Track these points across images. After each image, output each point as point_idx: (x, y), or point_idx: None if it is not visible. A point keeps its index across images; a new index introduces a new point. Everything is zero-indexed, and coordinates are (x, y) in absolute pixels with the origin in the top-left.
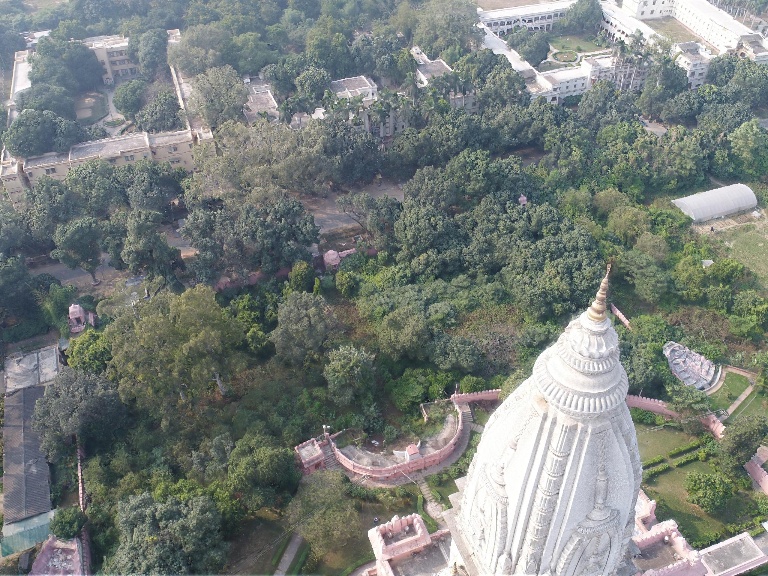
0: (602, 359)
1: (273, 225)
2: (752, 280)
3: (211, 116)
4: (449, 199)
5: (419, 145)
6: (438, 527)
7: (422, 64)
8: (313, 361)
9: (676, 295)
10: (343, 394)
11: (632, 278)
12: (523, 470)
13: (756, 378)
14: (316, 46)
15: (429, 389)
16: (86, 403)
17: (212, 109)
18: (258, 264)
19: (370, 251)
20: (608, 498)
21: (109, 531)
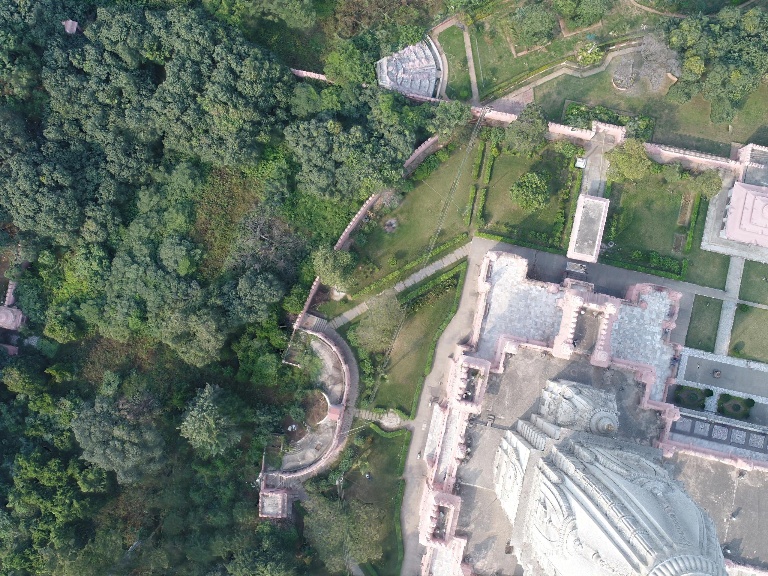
0: None
1: None
2: None
3: None
4: (17, 129)
5: None
6: (408, 429)
7: None
8: None
9: None
10: (229, 438)
11: (272, 14)
12: None
13: (461, 19)
14: None
15: (273, 345)
16: None
17: None
18: None
19: (25, 264)
20: None
21: None
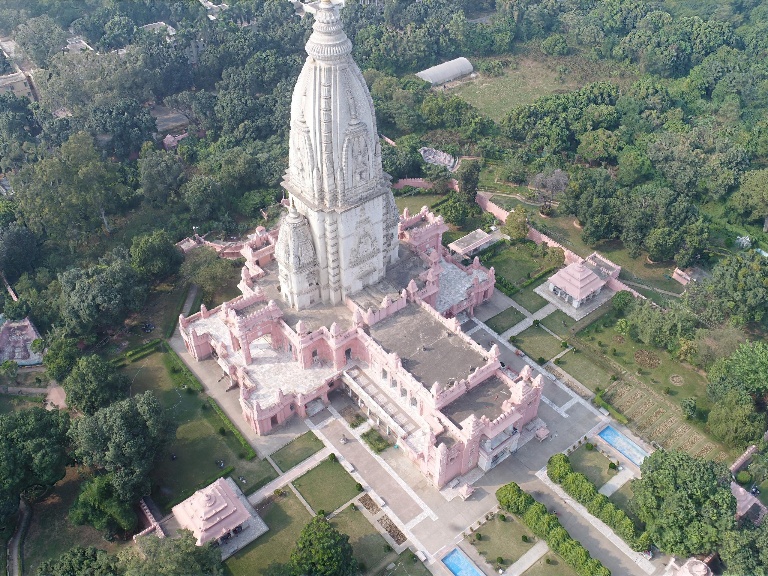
0: (334, 24)
1: (118, 118)
2: (473, 111)
3: (39, 57)
4: (252, 87)
5: (221, 57)
6: None
7: (209, 9)
8: (174, 203)
9: (425, 125)
10: (203, 210)
11: (394, 119)
12: (312, 103)
13: (480, 159)
14: (116, 0)
15: (264, 199)
16: (7, 235)
17: (38, 51)
18: (112, 151)
19: (200, 134)
20: (357, 113)
21: (50, 312)
